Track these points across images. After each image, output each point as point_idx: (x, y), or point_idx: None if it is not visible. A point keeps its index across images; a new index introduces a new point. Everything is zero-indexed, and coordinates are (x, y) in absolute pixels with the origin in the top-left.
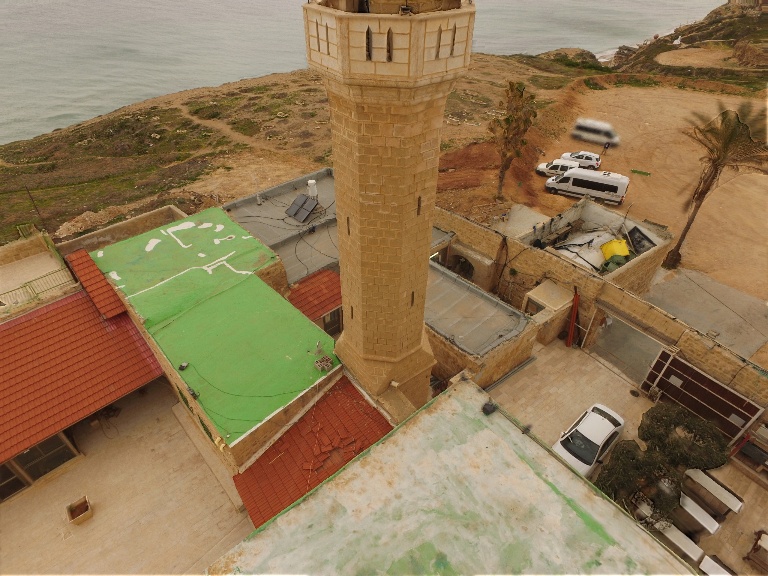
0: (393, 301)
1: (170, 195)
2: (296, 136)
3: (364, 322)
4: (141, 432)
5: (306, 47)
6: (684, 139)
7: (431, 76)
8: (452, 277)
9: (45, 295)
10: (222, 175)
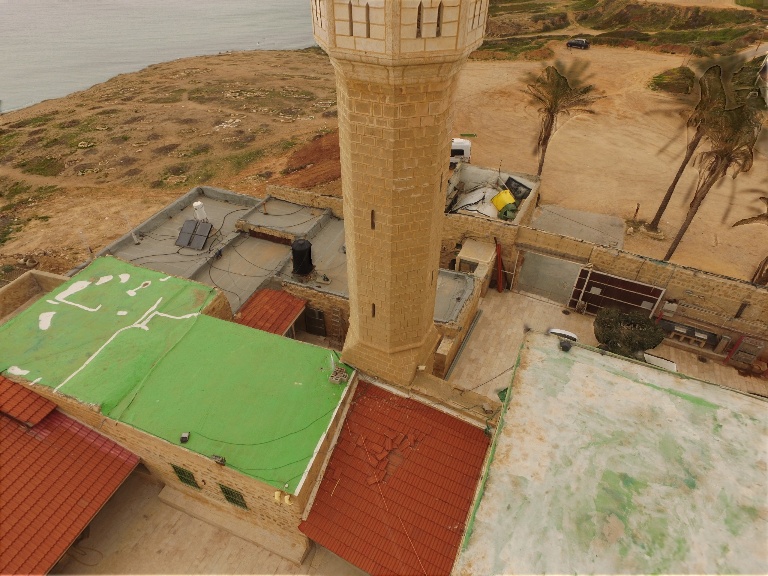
0: (421, 284)
1: None
2: (116, 165)
3: (391, 315)
4: (132, 539)
5: (328, 33)
6: (486, 101)
7: (469, 47)
8: None
9: None
10: (40, 227)
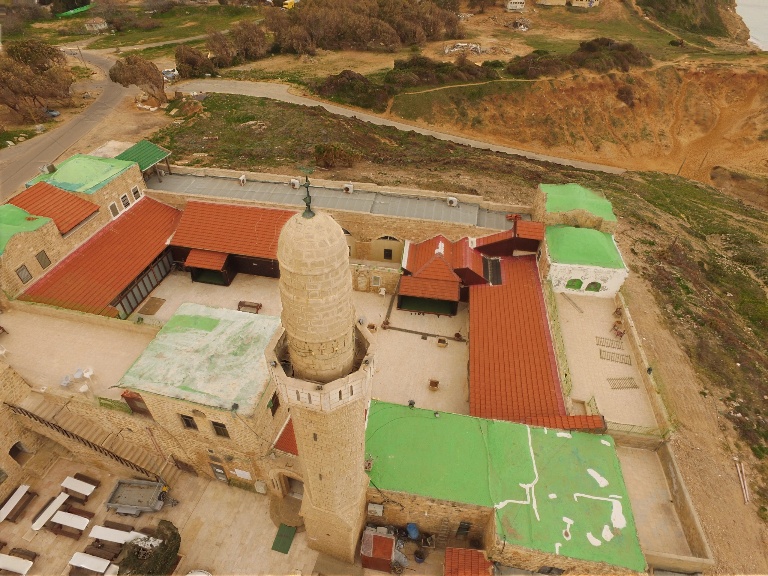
0: None
1: None
2: None
3: None
4: None
5: None
6: None
7: None
8: None
9: None
10: None
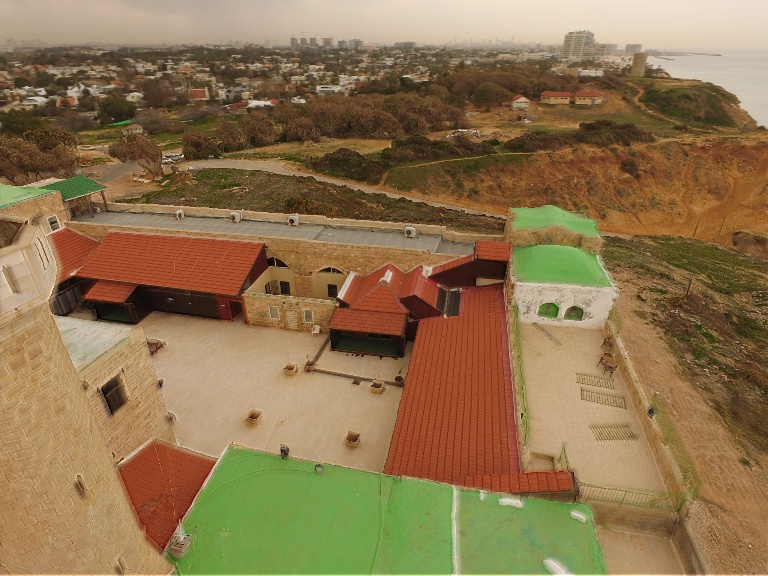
0: None
1: None
2: None
3: None
4: None
5: None
6: None
7: None
8: None
9: None
10: None
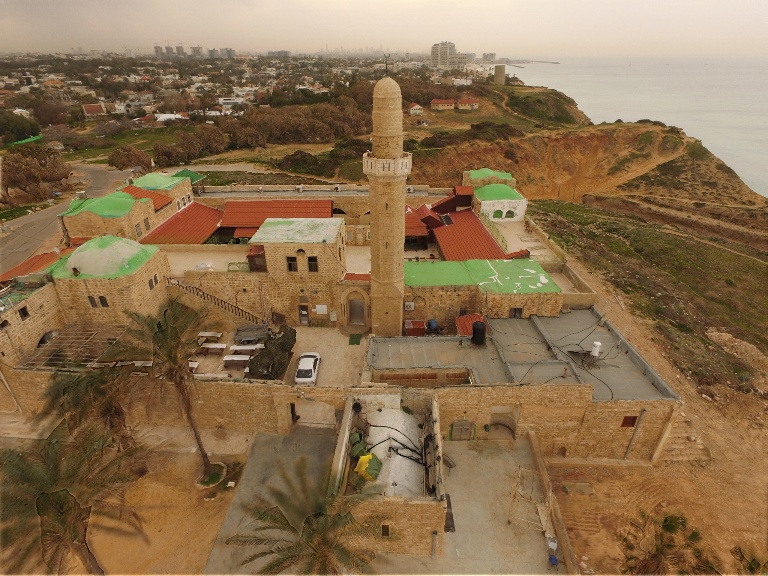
0: None
1: (760, 375)
2: None
3: None
4: None
5: None
6: None
7: None
8: None
9: None
10: None
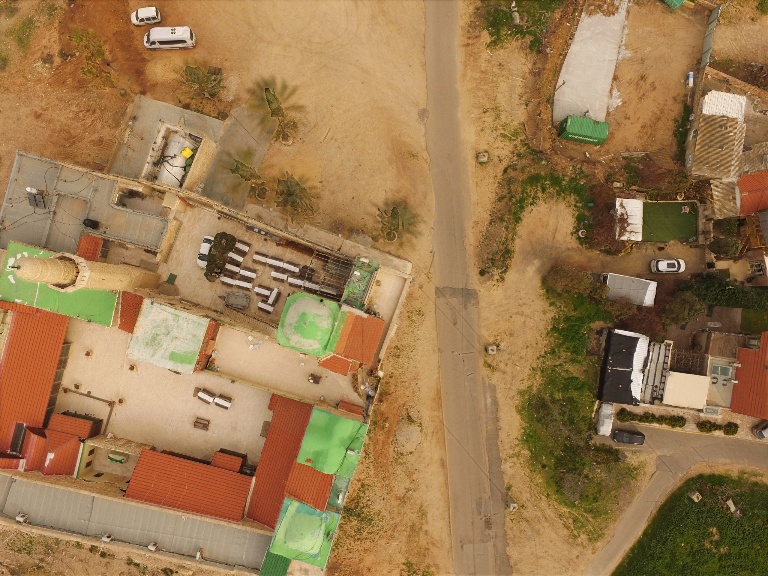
0: None
1: None
2: None
3: None
4: (80, 328)
5: None
6: None
7: None
8: (131, 212)
9: (6, 321)
10: None
